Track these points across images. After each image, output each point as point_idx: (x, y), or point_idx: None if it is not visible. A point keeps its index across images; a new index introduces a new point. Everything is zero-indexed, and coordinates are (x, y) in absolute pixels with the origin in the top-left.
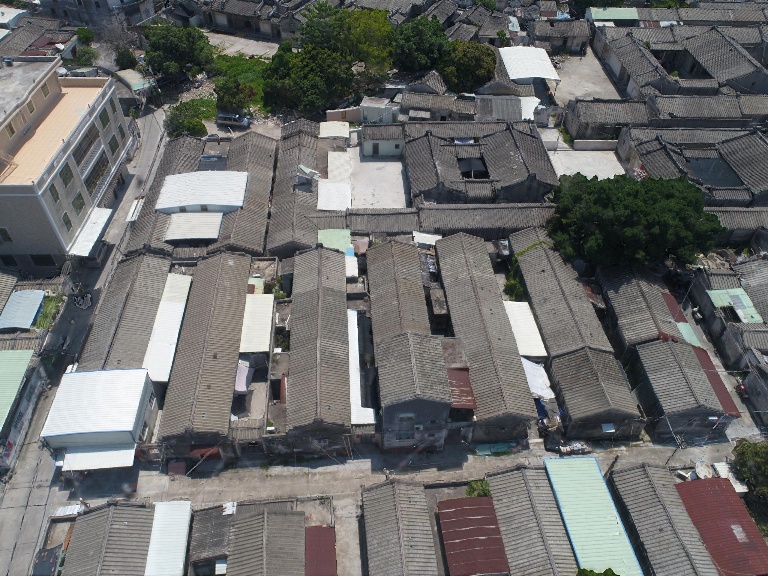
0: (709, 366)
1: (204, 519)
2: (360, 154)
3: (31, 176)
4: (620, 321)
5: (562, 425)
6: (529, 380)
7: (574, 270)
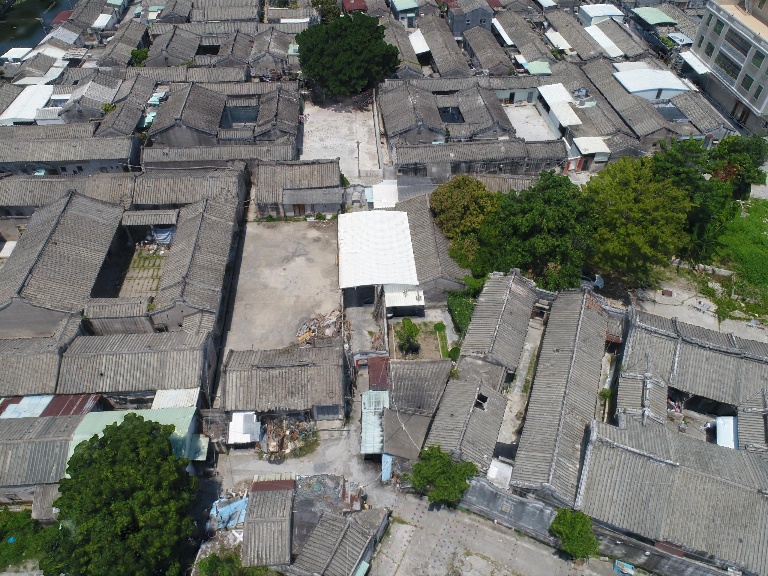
0: None
1: None
2: None
3: None
4: None
5: None
6: None
7: None
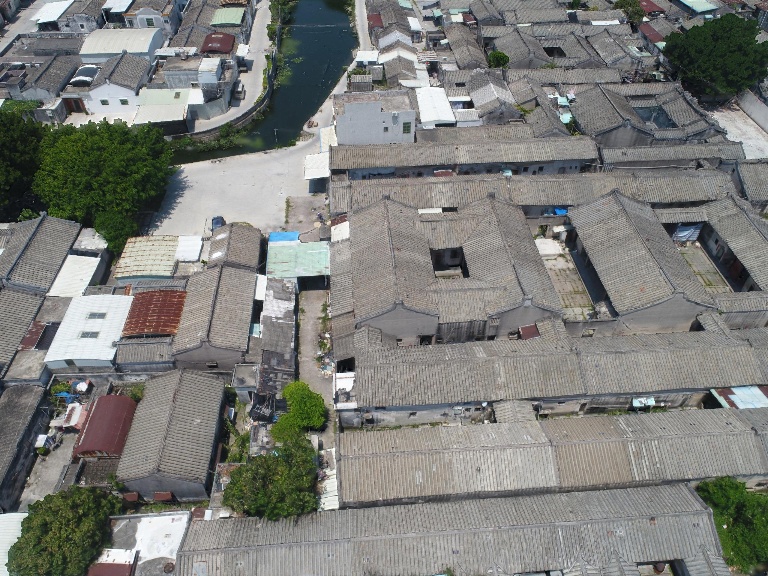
0: None
1: None
2: None
3: None
4: None
5: None
6: None
7: None
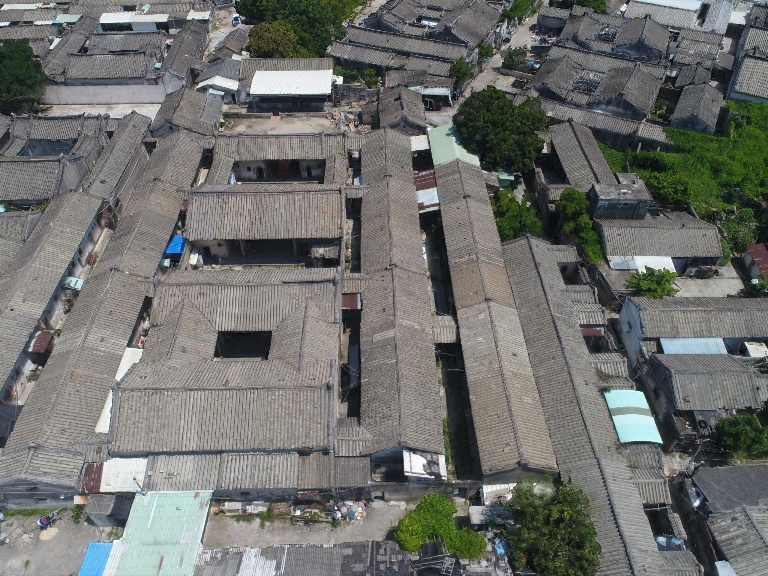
0: None
1: None
2: None
3: None
4: None
5: None
6: None
7: None
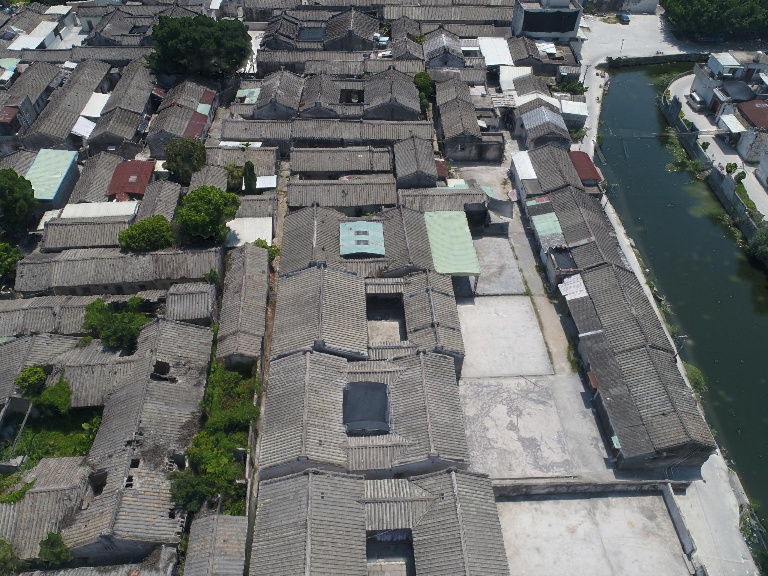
0: (199, 121)
1: None
2: (81, 30)
3: None
4: (162, 102)
5: (88, 149)
6: (78, 126)
7: (155, 78)
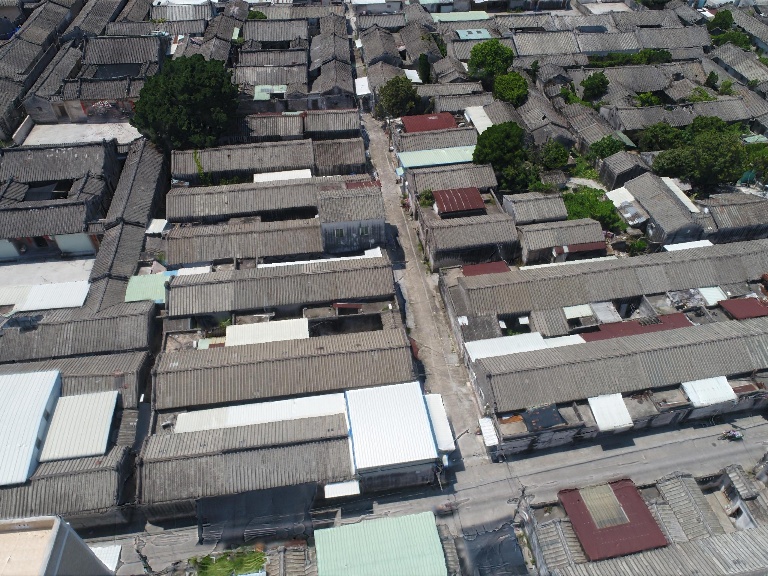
0: None
1: (472, 339)
2: None
3: (1, 563)
4: (281, 134)
5: None
6: None
7: (226, 145)
